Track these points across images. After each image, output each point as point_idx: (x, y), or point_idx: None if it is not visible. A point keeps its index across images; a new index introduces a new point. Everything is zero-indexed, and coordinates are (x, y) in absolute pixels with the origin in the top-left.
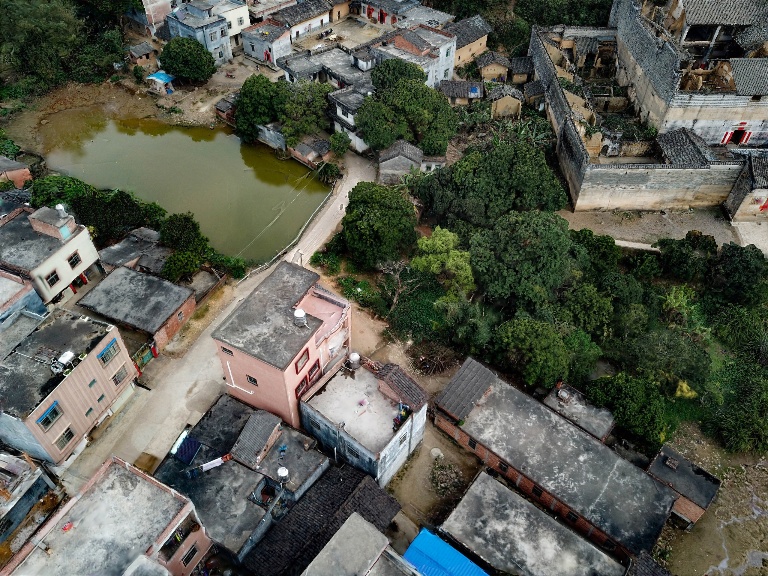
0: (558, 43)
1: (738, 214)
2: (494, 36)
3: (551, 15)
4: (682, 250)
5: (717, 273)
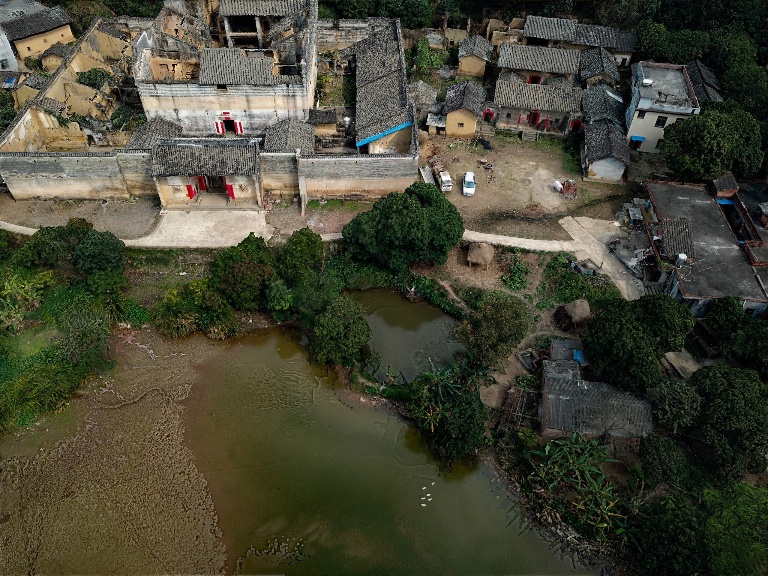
0: (129, 34)
1: (171, 203)
2: (78, 27)
3: (129, 6)
4: (44, 237)
5: (64, 260)
